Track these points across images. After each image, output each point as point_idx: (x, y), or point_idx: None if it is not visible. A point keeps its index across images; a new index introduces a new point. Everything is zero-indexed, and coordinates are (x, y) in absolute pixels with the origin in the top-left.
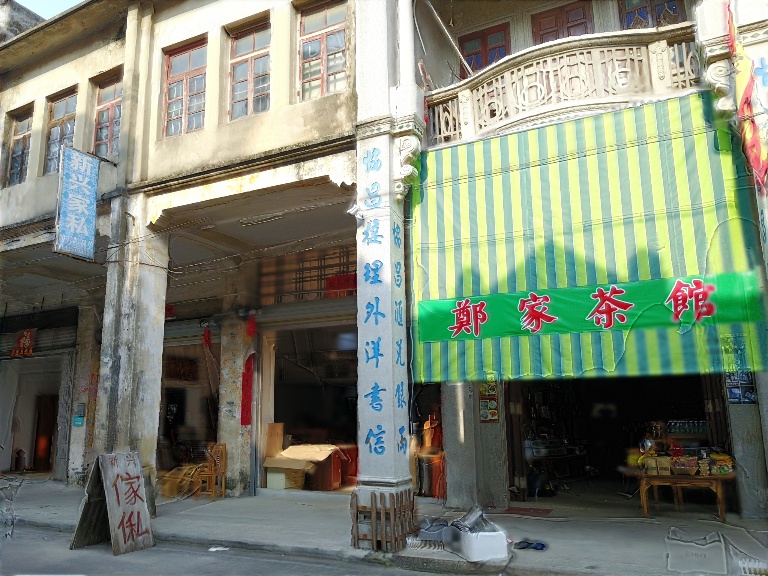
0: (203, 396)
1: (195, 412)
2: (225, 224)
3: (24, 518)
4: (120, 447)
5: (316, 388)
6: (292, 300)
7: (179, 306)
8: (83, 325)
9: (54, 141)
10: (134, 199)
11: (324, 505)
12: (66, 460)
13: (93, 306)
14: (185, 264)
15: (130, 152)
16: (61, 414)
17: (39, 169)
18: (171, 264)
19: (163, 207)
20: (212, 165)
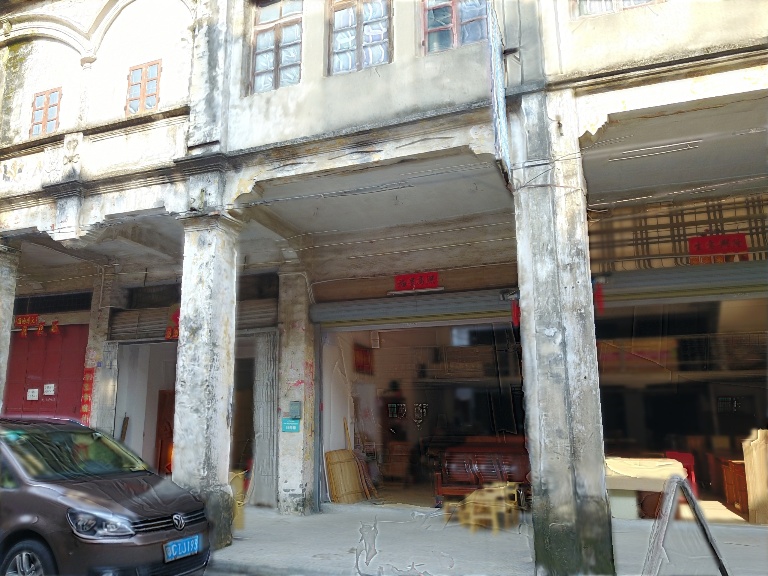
0: (482, 393)
1: (455, 414)
2: (602, 154)
3: (390, 574)
4: (589, 466)
5: (657, 384)
6: (635, 267)
7: (448, 273)
8: (288, 297)
9: (345, 28)
10: (557, 97)
11: (767, 545)
12: (274, 478)
13: (304, 272)
14: (454, 219)
15: (540, 31)
16: (261, 415)
17: (324, 65)
18: (588, 198)
19: (610, 110)
20: (729, 44)
